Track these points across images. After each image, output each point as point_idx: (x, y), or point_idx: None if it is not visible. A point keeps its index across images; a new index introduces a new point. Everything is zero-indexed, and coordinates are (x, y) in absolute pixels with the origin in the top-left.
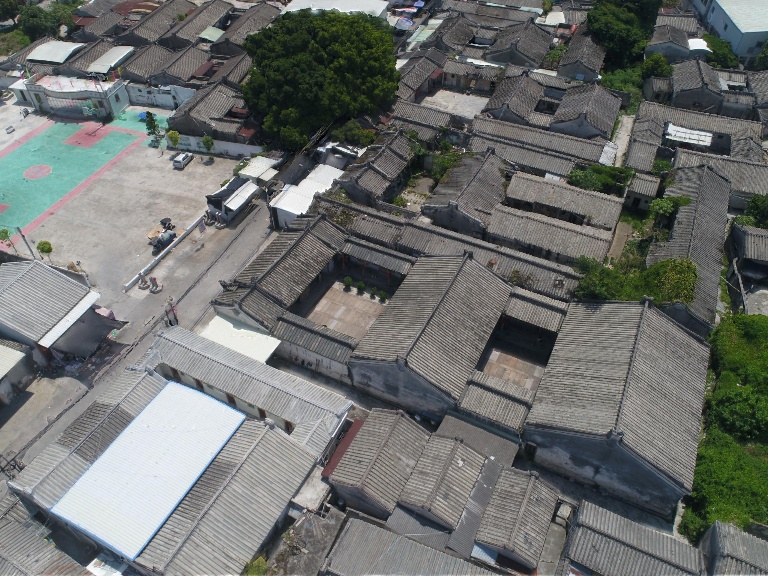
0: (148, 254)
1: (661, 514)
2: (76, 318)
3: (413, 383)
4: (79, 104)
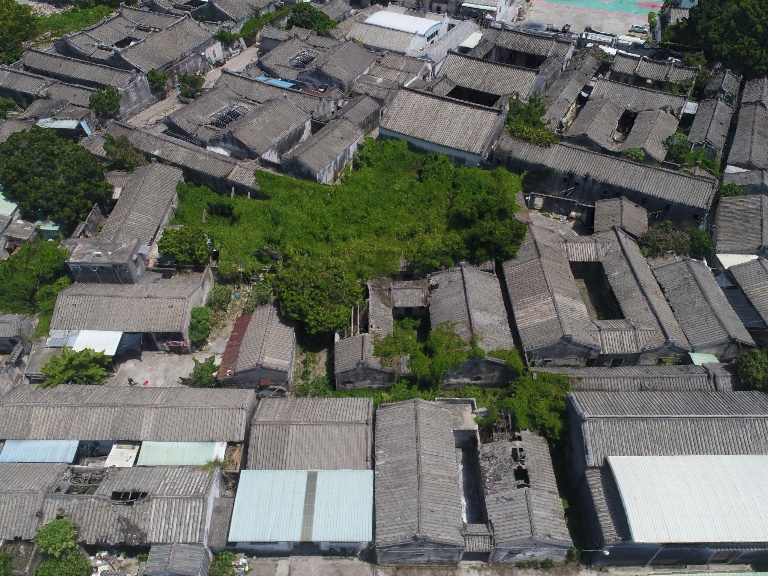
0: None
1: None
2: (480, 8)
3: None
4: None
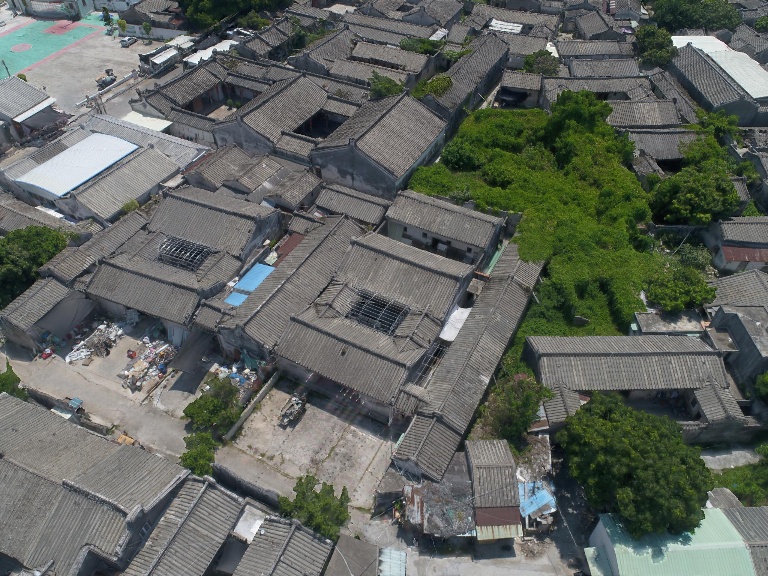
0: (95, 91)
1: None
2: (39, 110)
3: (249, 136)
4: (55, 7)
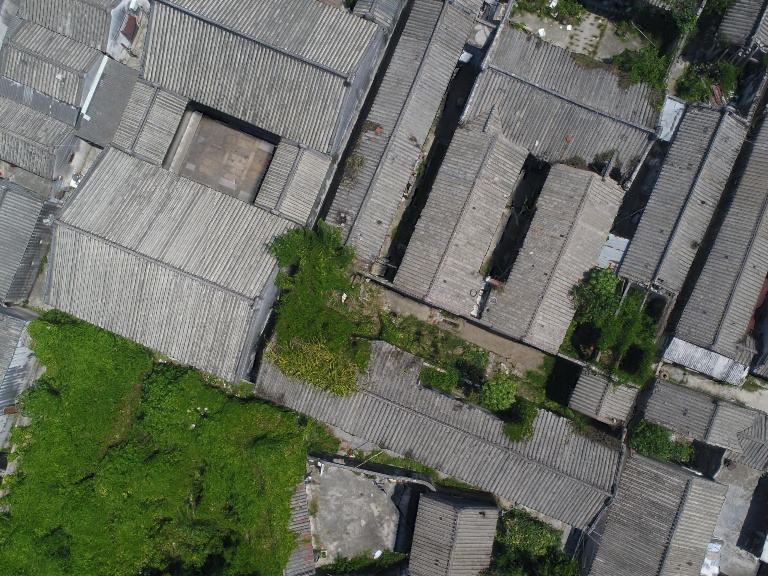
0: None
1: None
2: None
3: None
4: None
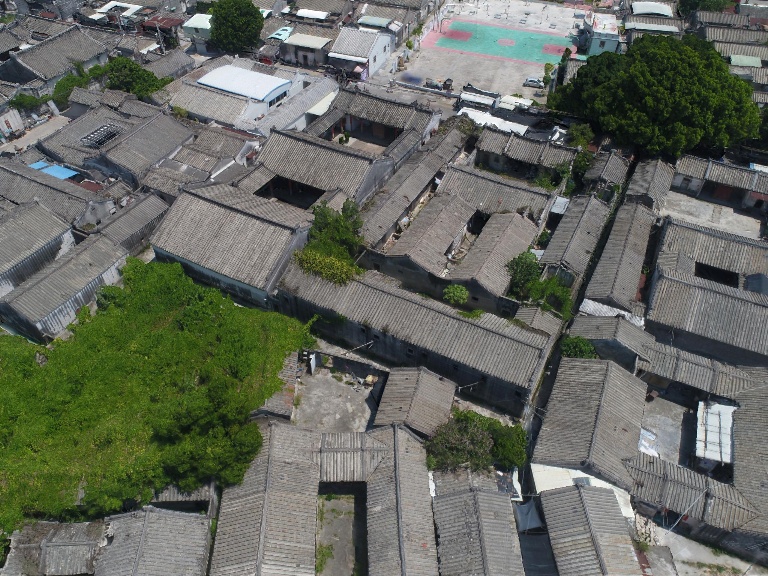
0: None
1: None
2: (348, 59)
3: None
4: None
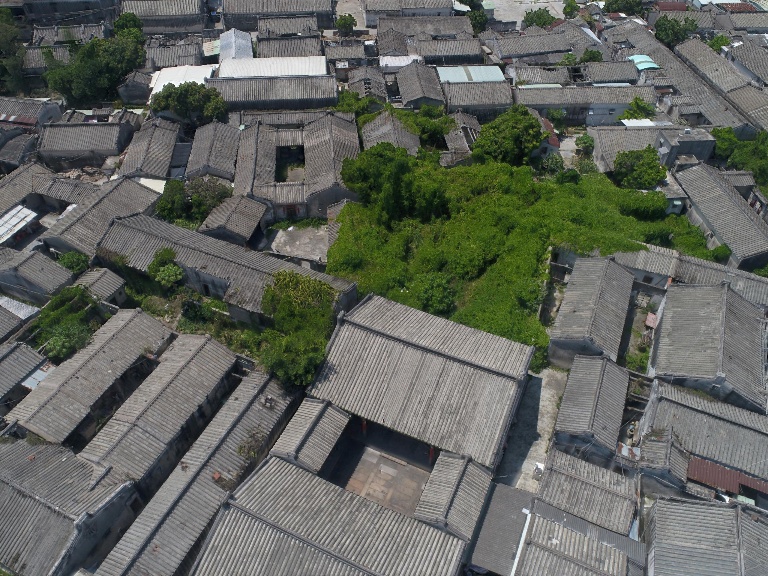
0: None
1: (526, 382)
2: None
3: None
4: None
